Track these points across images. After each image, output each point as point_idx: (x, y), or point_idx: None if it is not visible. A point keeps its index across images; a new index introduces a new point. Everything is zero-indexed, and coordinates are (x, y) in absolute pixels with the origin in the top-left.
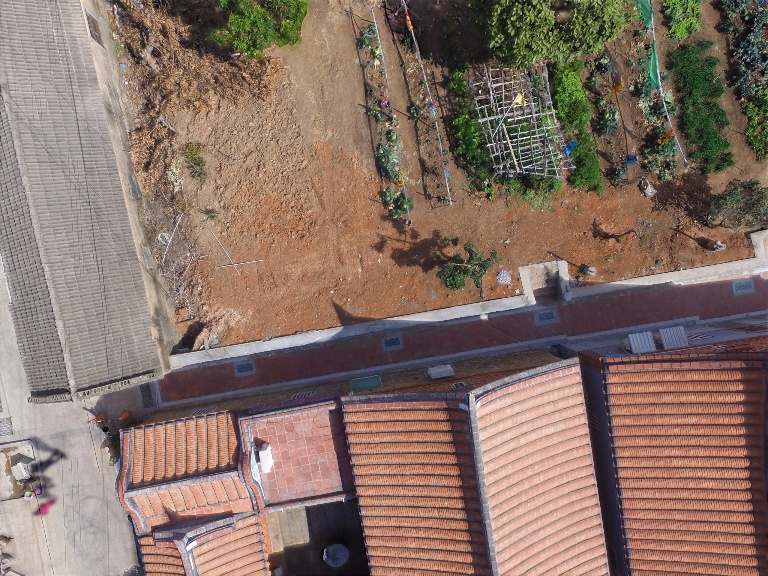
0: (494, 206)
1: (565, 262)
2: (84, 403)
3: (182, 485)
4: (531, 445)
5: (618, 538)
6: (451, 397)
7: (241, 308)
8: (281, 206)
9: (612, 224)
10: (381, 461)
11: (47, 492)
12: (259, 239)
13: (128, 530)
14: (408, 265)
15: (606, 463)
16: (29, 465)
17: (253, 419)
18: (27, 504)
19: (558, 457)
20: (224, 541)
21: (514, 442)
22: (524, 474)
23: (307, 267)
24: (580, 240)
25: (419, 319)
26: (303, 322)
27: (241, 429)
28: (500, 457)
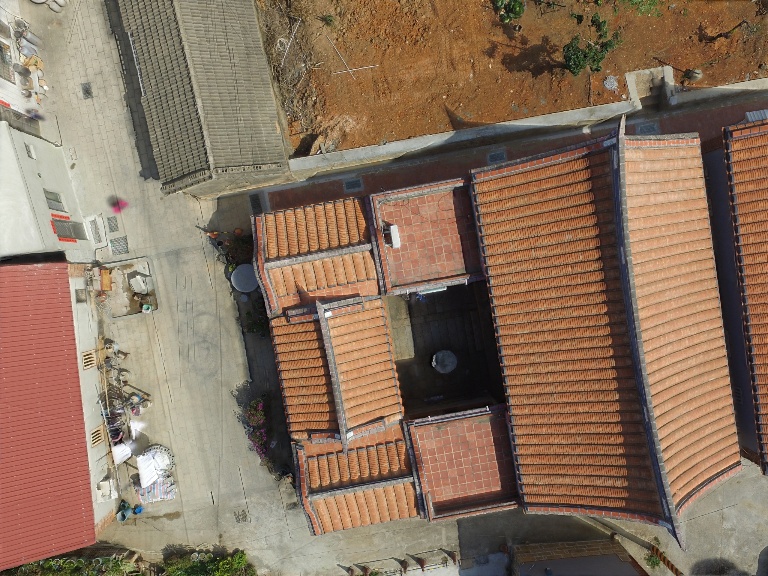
0: (602, 11)
1: (670, 67)
2: (197, 221)
3: (318, 257)
4: (659, 206)
5: (736, 309)
6: (592, 143)
7: (356, 114)
8: (396, 11)
9: (717, 28)
10: (512, 227)
11: (162, 308)
12: (374, 45)
13: (240, 346)
14: (518, 71)
15: (723, 239)
16: (147, 279)
17: (384, 195)
18: (143, 320)
19: (681, 225)
20: (354, 319)
21: (646, 198)
22: (653, 232)
23: (420, 73)
24: (686, 44)
25: (529, 123)
26: (416, 127)
27: (373, 205)
28: (635, 208)
